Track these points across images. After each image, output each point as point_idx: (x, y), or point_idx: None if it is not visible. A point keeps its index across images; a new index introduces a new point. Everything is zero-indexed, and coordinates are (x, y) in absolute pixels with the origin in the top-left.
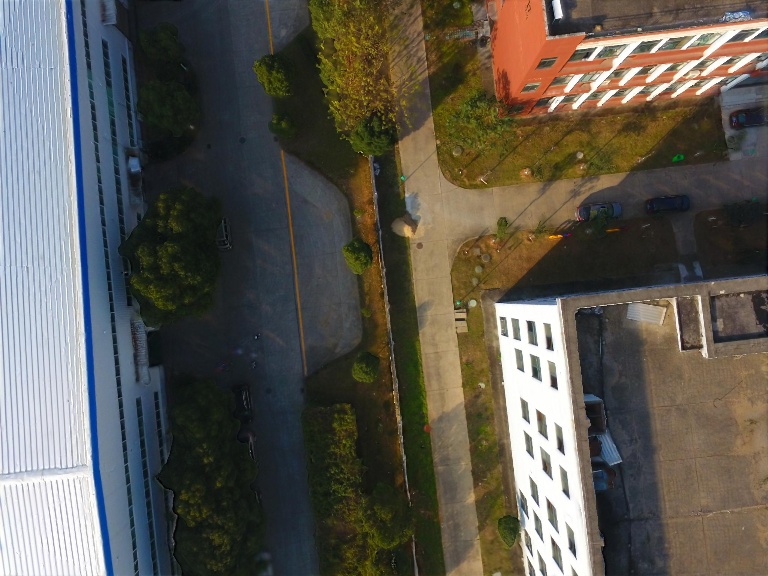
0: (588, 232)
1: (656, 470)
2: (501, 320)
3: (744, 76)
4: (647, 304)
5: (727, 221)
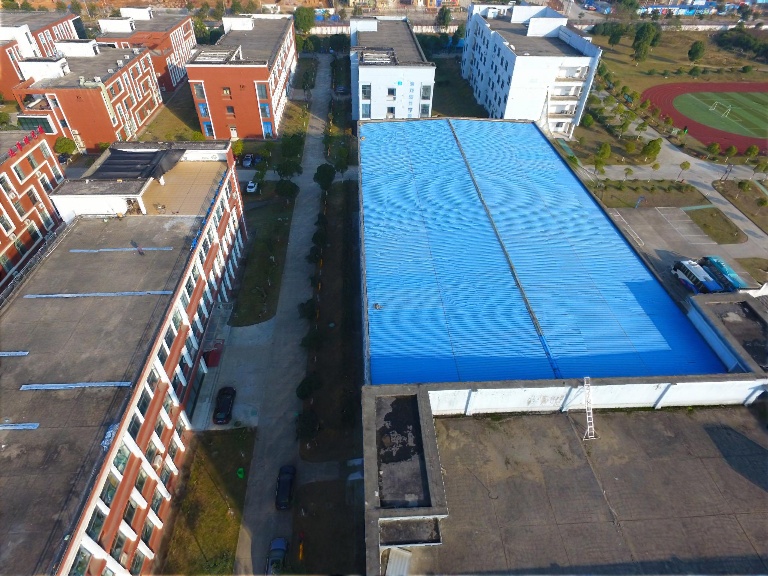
0: None
1: (582, 573)
2: None
3: (182, 414)
4: (386, 570)
5: None
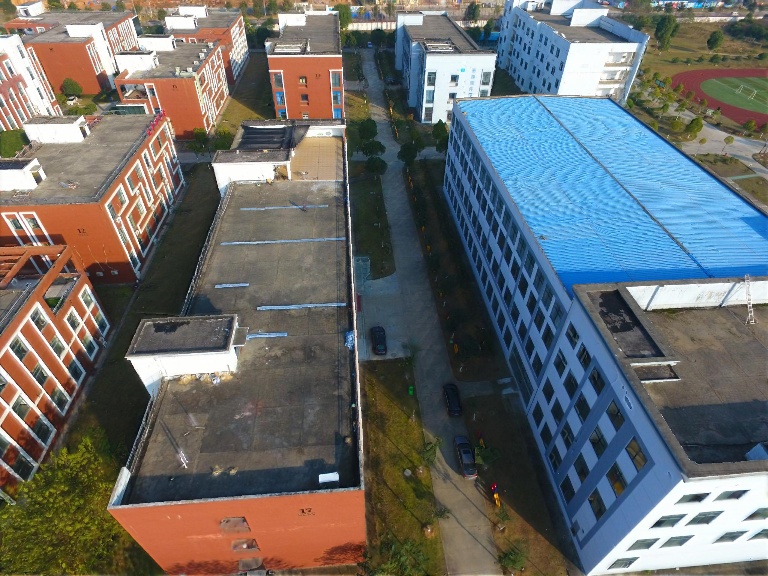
0: (486, 468)
1: None
2: (612, 567)
3: None
4: None
5: (461, 360)
